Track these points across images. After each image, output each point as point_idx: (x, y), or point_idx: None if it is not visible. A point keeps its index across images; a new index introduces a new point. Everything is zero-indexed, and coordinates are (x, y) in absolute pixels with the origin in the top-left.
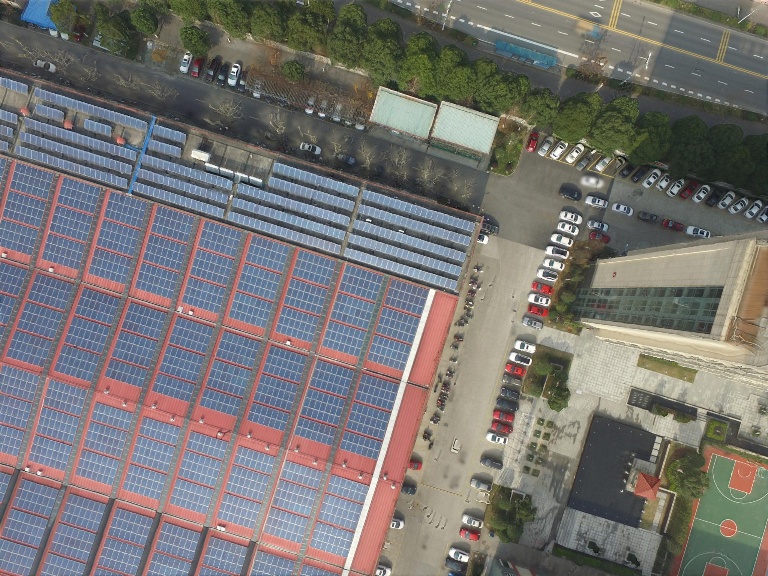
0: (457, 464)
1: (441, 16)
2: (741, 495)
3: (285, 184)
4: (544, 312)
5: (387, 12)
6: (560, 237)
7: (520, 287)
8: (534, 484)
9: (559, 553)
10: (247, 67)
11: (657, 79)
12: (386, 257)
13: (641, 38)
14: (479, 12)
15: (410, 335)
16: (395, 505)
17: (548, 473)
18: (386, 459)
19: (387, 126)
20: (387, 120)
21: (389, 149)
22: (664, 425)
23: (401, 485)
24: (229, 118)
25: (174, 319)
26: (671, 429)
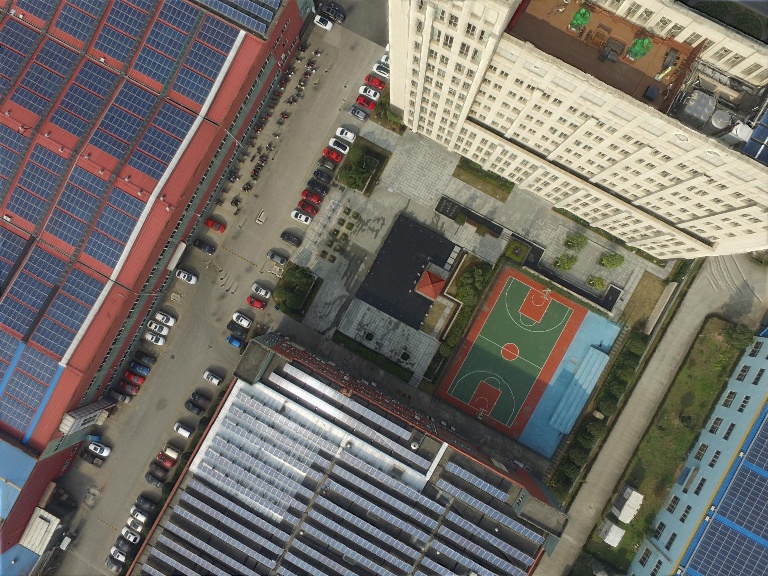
0: (259, 235)
1: None
2: (530, 322)
3: None
4: (371, 105)
5: None
6: None
7: (354, 78)
8: (328, 269)
9: (338, 339)
10: None
11: None
12: None
13: None
14: None
15: (215, 72)
16: (166, 226)
17: (344, 262)
18: (168, 183)
19: None
20: None
21: None
22: (465, 236)
23: (175, 208)
24: None
25: (5, 20)
26: (472, 241)
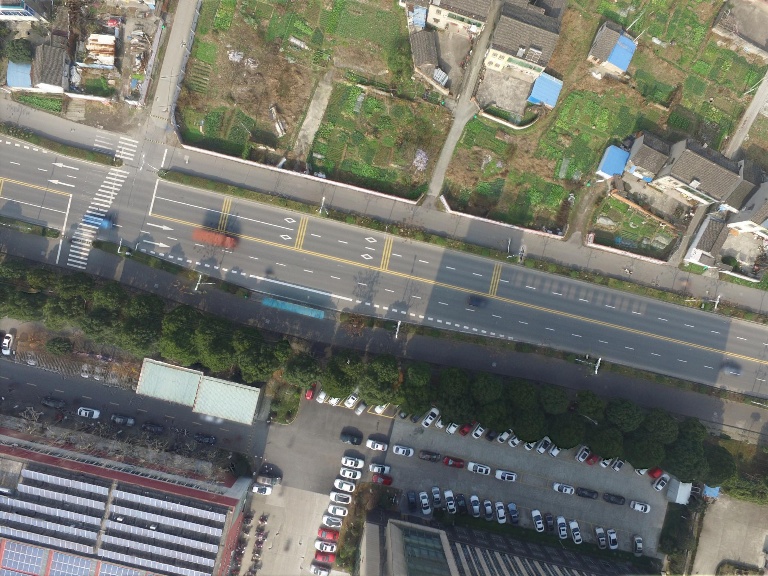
0: None
1: (213, 269)
2: None
3: (34, 490)
4: (330, 559)
5: (158, 269)
6: (341, 484)
7: (307, 533)
8: None
9: None
10: (21, 334)
11: (432, 317)
12: (141, 552)
13: (413, 278)
14: (250, 262)
15: None
16: None
17: None
18: None
19: (154, 397)
20: (154, 391)
21: (168, 407)
22: None
23: None
24: (6, 386)
25: None
26: None
